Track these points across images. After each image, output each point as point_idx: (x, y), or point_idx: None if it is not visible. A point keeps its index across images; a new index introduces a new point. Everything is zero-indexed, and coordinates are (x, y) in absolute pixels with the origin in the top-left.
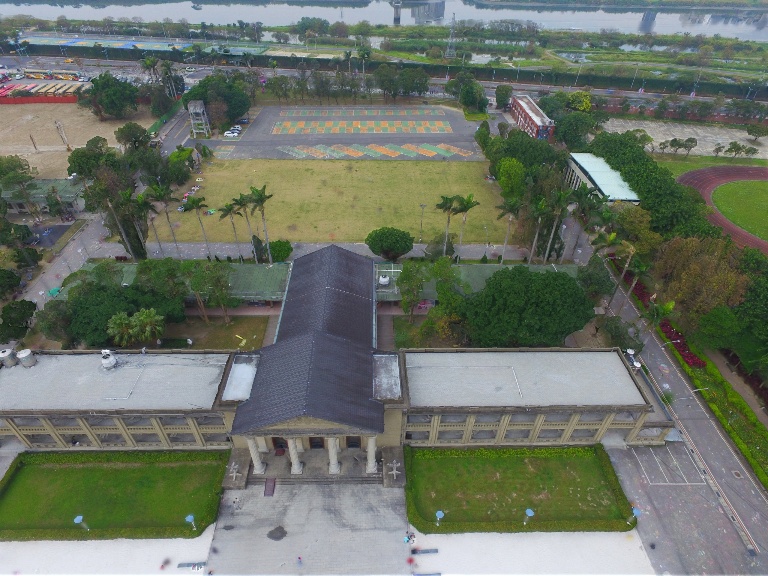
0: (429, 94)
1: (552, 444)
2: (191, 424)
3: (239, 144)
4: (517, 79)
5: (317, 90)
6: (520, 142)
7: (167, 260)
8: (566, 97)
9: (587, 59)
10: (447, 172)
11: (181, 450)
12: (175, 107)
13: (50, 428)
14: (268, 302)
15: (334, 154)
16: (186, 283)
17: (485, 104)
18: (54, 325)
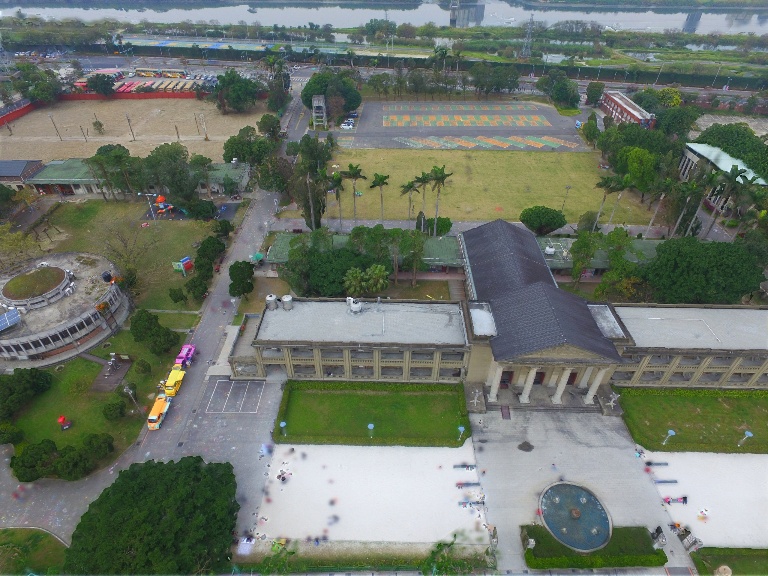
0: (517, 91)
1: (739, 387)
2: (437, 358)
3: (357, 135)
4: (598, 77)
5: (415, 87)
6: (637, 133)
7: (379, 226)
8: (656, 93)
9: (657, 58)
10: (560, 161)
11: (417, 383)
12: (289, 102)
13: (318, 359)
14: (444, 269)
15: (448, 145)
16: (389, 247)
17: (577, 100)
18: (300, 277)
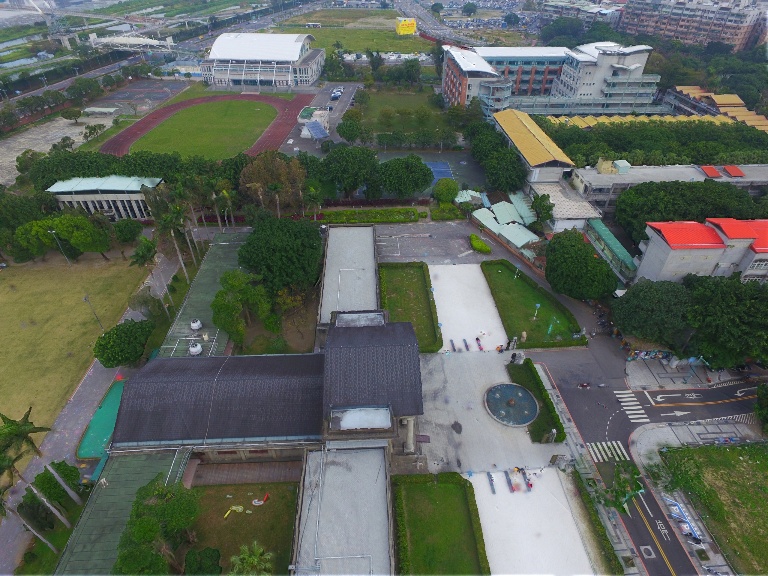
0: None
1: None
2: None
3: None
4: None
5: None
6: None
7: (127, 558)
8: None
9: None
10: None
11: None
12: None
13: None
14: None
15: None
16: None
17: None
18: None
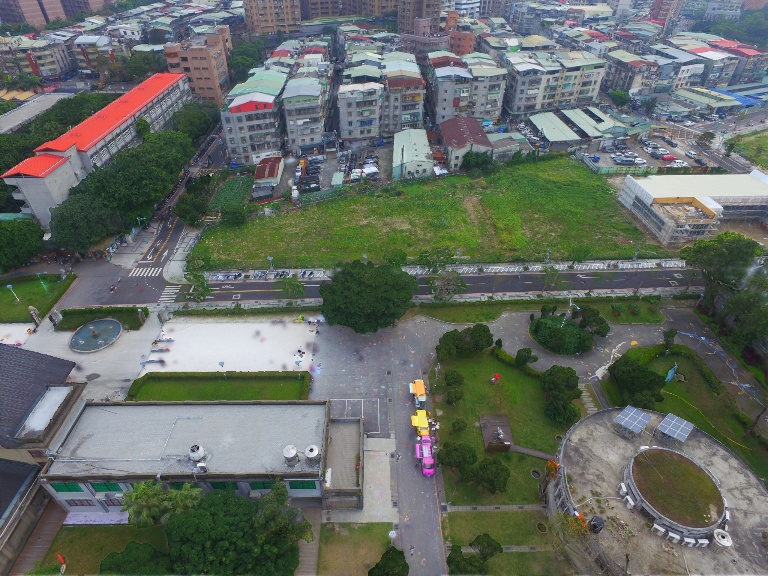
0: None
1: None
2: None
3: None
4: None
5: None
6: None
7: None
8: None
9: None
10: None
11: None
12: None
13: None
14: None
15: None
16: None
17: None
18: None
